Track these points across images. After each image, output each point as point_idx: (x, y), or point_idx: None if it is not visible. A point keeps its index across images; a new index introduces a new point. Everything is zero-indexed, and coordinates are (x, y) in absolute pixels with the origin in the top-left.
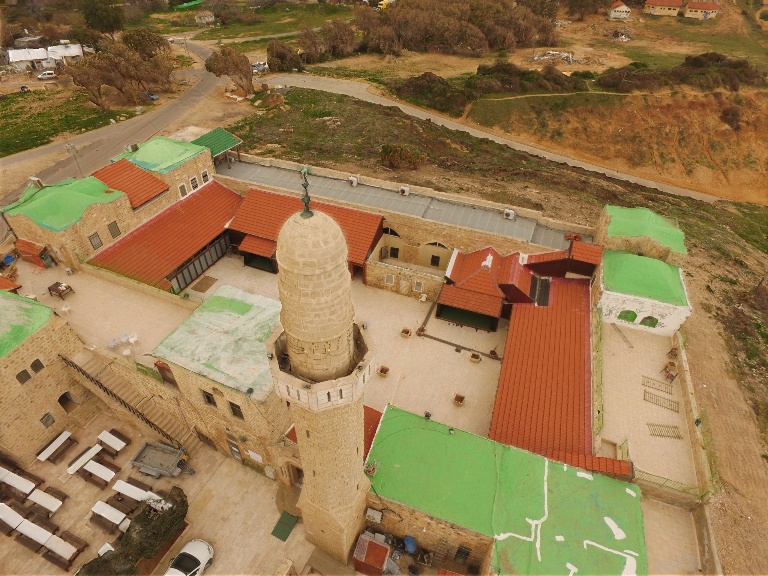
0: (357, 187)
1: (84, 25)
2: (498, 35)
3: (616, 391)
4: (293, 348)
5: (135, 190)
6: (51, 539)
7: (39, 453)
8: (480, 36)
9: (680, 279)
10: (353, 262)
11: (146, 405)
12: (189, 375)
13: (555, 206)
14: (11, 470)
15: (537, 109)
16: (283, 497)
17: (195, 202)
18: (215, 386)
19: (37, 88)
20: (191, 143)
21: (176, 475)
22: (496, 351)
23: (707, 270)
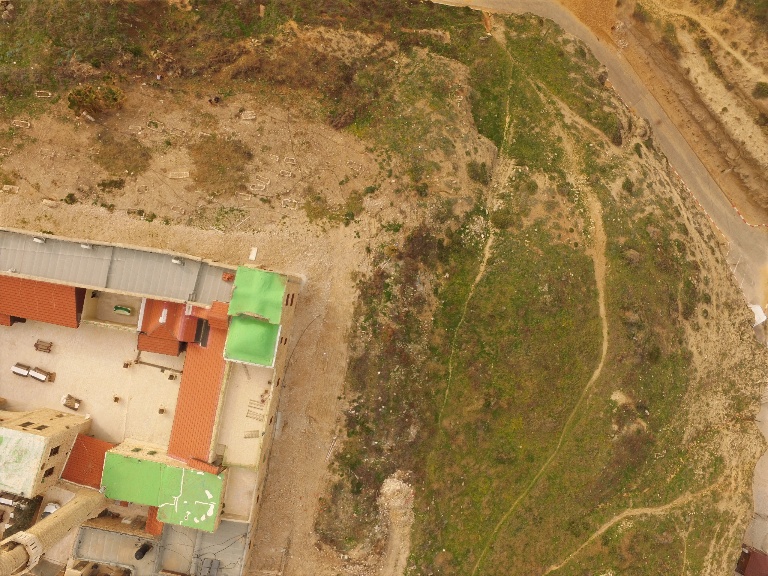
0: (46, 243)
1: None
2: None
3: (233, 413)
4: None
5: None
6: None
7: None
8: None
9: (276, 338)
10: None
11: None
12: None
13: (266, 145)
14: None
15: None
16: None
17: None
18: None
19: None
20: None
21: None
22: None
23: (380, 219)
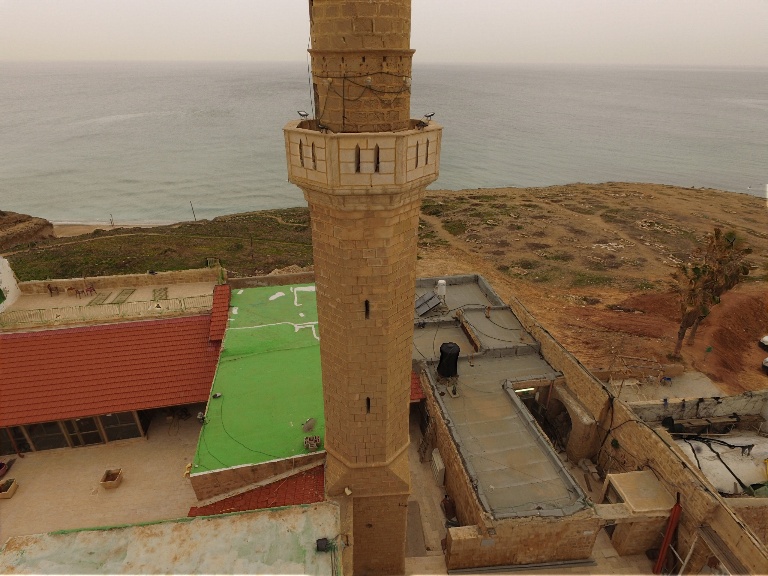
0: None
1: None
2: None
3: None
4: None
5: None
6: None
7: None
8: None
9: None
10: None
11: None
12: None
13: None
14: None
15: None
16: None
17: None
18: None
19: None
20: None
21: None
22: None
23: None
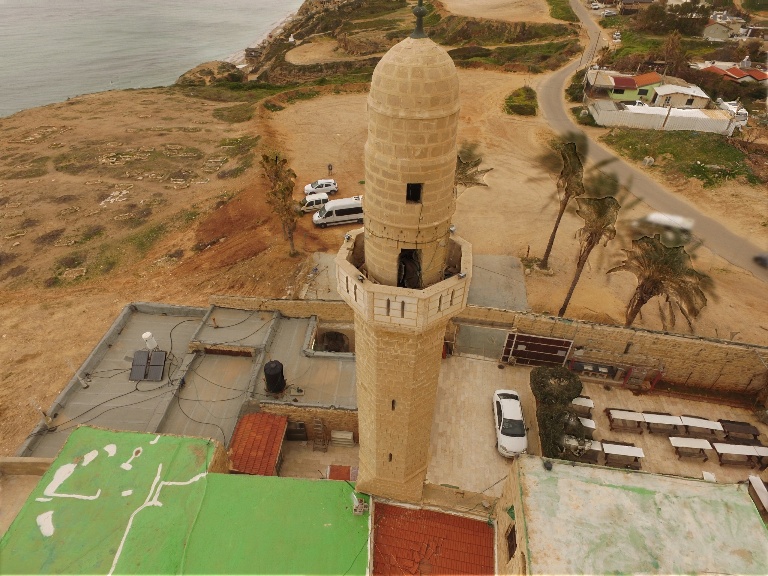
0: None
1: None
2: None
3: None
4: None
5: None
6: (642, 418)
7: (766, 483)
8: None
9: None
10: None
11: None
12: None
13: None
14: (764, 462)
15: None
16: None
17: None
18: None
19: None
20: None
21: None
22: None
23: None
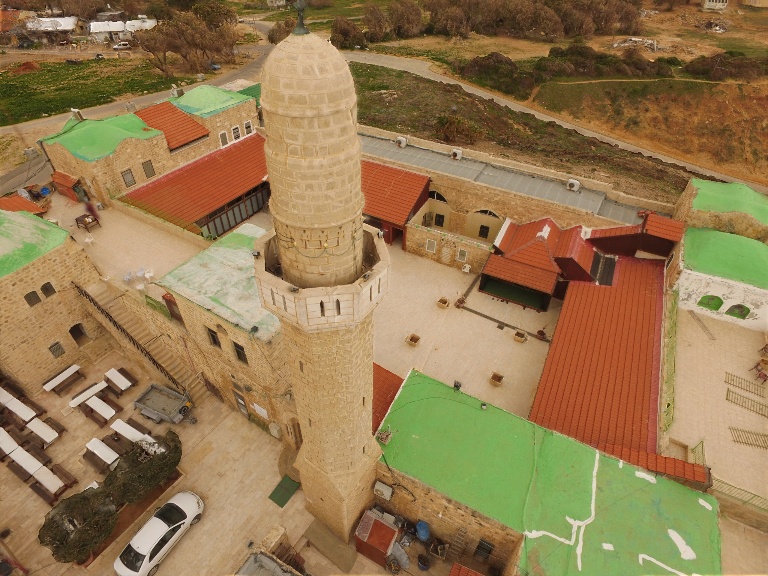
0: (405, 148)
1: (162, 3)
2: (575, 20)
3: (691, 386)
4: (282, 240)
5: (174, 132)
6: (41, 470)
7: (46, 383)
8: (555, 19)
9: None
10: (393, 224)
11: (155, 345)
12: (193, 308)
13: (626, 191)
14: (16, 396)
15: (612, 95)
16: (287, 459)
17: (235, 152)
18: (218, 322)
19: (111, 57)
20: (237, 92)
21: (177, 421)
22: (545, 332)
23: None
